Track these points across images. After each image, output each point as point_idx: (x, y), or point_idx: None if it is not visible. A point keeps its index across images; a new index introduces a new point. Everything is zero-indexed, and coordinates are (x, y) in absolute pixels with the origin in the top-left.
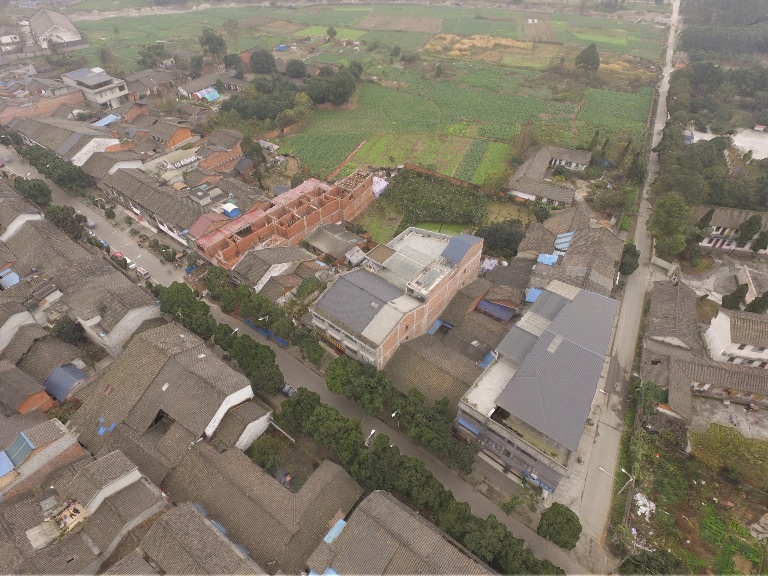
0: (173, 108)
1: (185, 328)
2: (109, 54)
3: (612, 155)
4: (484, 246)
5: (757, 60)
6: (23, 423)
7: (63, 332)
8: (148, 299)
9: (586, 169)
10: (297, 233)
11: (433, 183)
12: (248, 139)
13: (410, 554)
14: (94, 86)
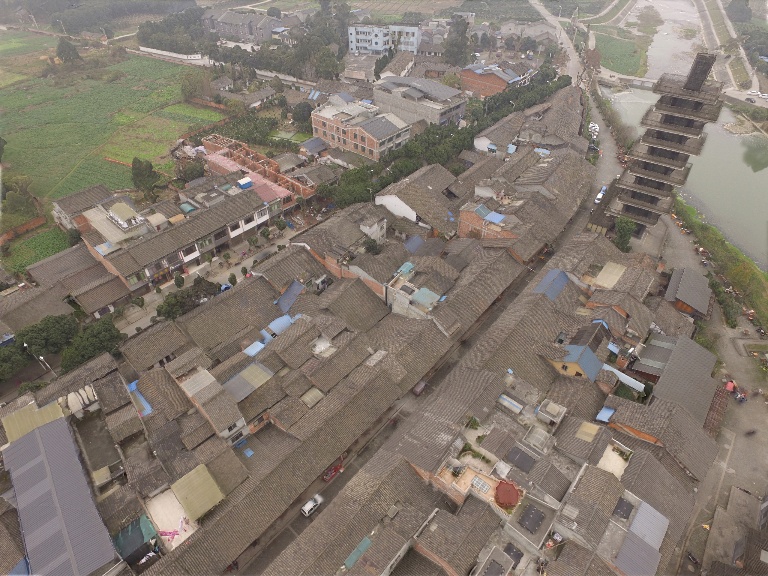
0: None
1: (381, 190)
2: None
3: None
4: (302, 123)
5: (127, 21)
6: None
7: None
8: None
9: (234, 86)
10: None
11: (215, 132)
12: None
13: (499, 129)
14: None
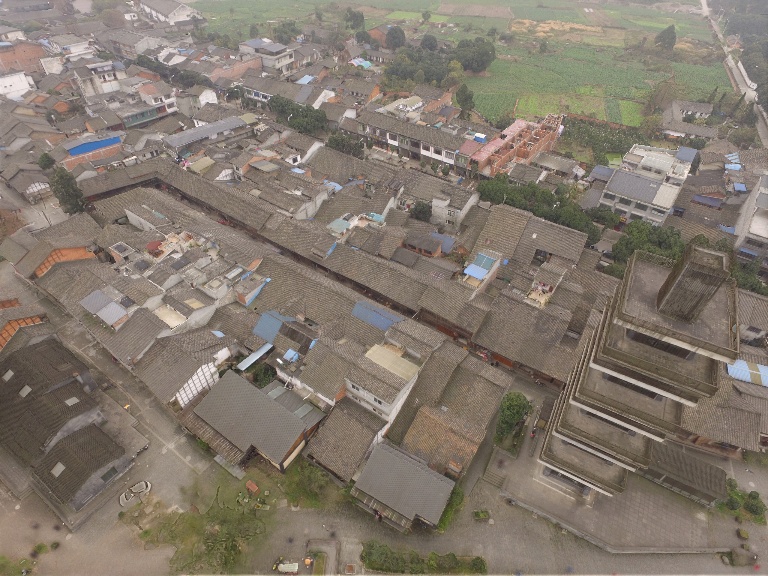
0: (347, 72)
1: (513, 207)
2: (269, 27)
3: (723, 108)
4: None
5: None
6: (441, 261)
7: (422, 212)
8: (472, 190)
9: (709, 117)
10: (531, 155)
11: (597, 127)
12: (466, 88)
13: (766, 303)
14: (275, 53)
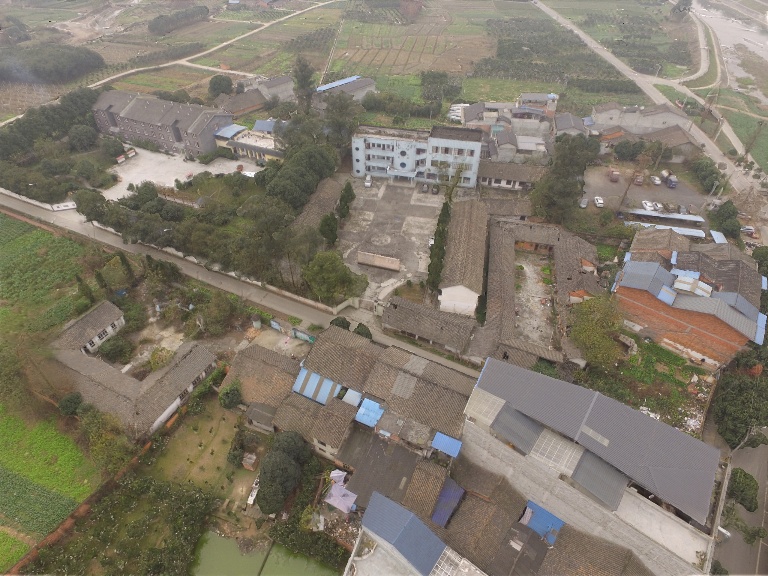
0: None
1: None
2: None
3: None
4: None
5: None
6: None
7: None
8: None
9: (126, 318)
10: None
11: None
12: None
13: None
14: None
